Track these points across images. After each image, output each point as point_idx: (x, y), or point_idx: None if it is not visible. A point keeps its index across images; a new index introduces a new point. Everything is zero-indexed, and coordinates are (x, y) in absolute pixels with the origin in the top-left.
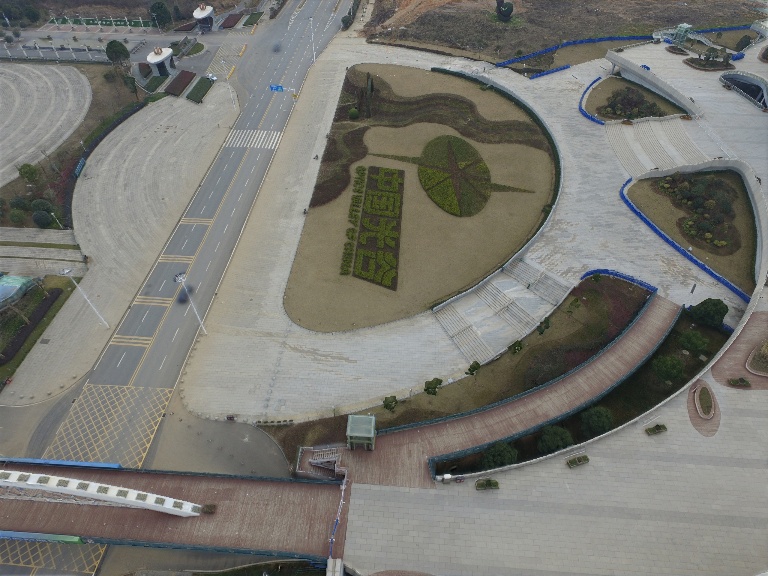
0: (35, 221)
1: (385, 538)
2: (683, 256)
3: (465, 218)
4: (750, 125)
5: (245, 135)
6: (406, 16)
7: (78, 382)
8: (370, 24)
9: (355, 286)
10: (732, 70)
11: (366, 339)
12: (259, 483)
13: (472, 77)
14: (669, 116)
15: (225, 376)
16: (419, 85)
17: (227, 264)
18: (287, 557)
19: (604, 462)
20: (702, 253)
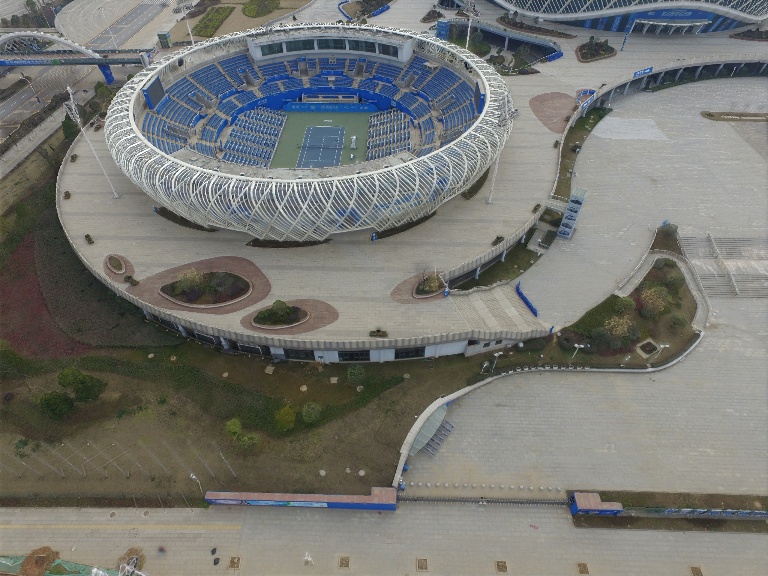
0: (36, 22)
1: None
2: None
3: (257, 18)
4: None
5: (154, 0)
6: None
7: None
8: None
9: None
10: None
11: None
12: None
13: None
14: None
15: None
16: None
17: (133, 36)
18: None
19: None
20: None
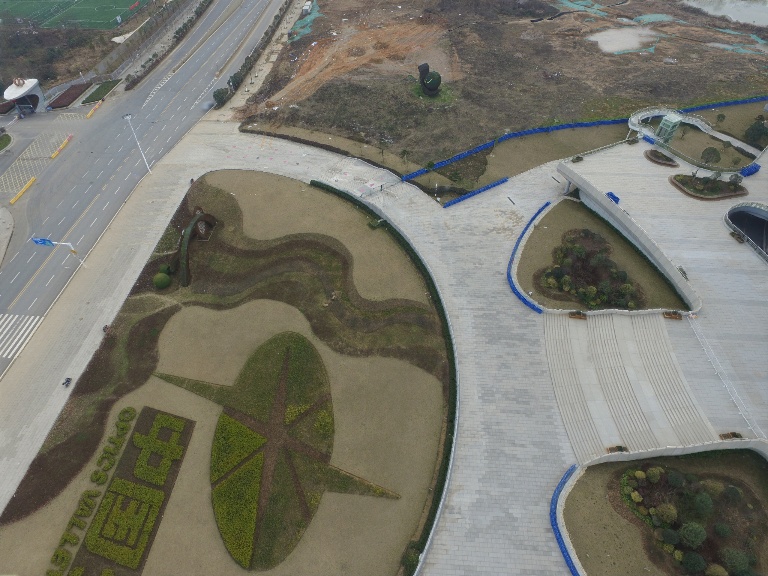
0: None
1: None
2: None
3: (257, 575)
4: None
5: None
6: (302, 87)
7: None
8: (254, 98)
9: None
10: None
11: None
12: None
13: (361, 202)
14: (645, 310)
15: None
16: (283, 215)
17: None
18: None
19: None
20: None
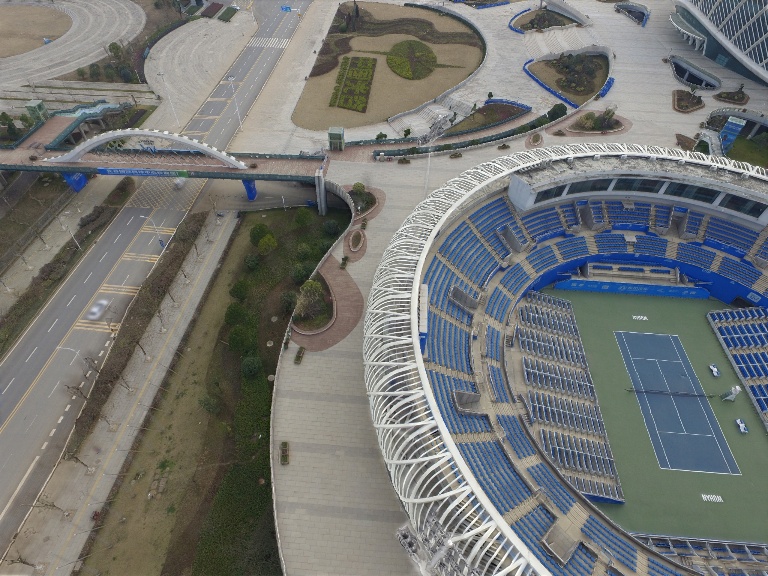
0: (123, 76)
1: (347, 176)
2: (555, 96)
3: (415, 80)
4: (624, 31)
5: (263, 40)
6: None
7: (165, 148)
8: None
9: (338, 111)
10: (625, 1)
11: (344, 133)
12: (280, 159)
13: (434, 8)
14: (568, 25)
15: (255, 147)
16: (394, 14)
17: (253, 103)
18: (294, 205)
19: (471, 157)
20: (567, 94)
